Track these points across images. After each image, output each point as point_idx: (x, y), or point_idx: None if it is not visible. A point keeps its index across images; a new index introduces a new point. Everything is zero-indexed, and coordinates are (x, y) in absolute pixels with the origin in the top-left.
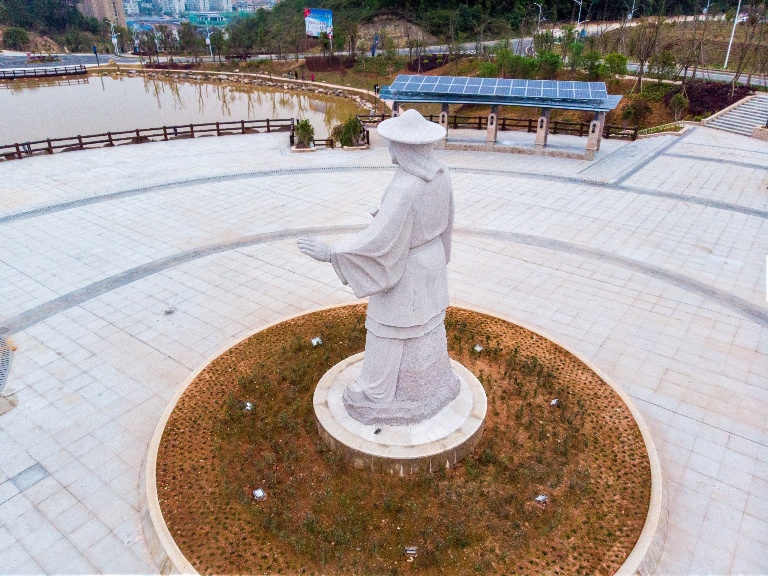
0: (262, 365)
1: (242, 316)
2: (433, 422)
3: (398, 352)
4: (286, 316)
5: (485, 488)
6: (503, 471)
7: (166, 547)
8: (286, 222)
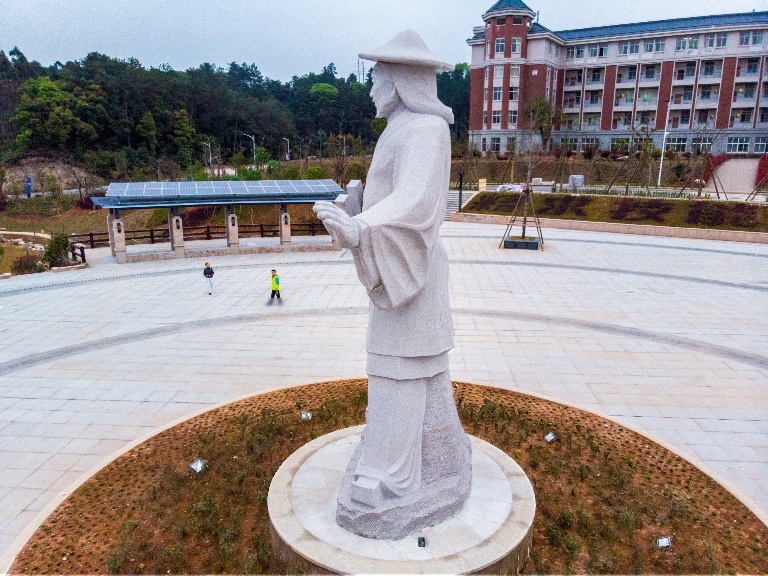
0: (132, 526)
1: (23, 477)
2: (478, 500)
3: (421, 402)
4: (108, 454)
5: (596, 562)
6: (588, 532)
7: None
8: (23, 347)
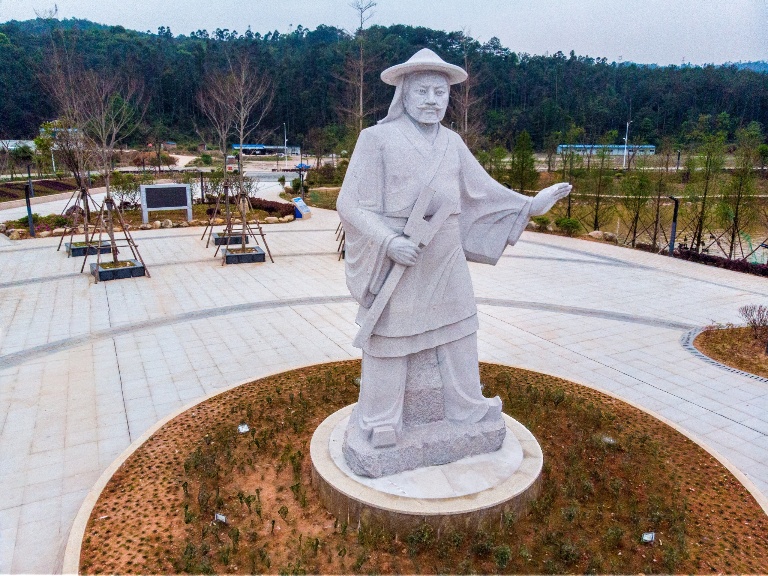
0: None
1: None
2: None
3: None
4: None
5: None
6: None
7: (693, 435)
8: None
